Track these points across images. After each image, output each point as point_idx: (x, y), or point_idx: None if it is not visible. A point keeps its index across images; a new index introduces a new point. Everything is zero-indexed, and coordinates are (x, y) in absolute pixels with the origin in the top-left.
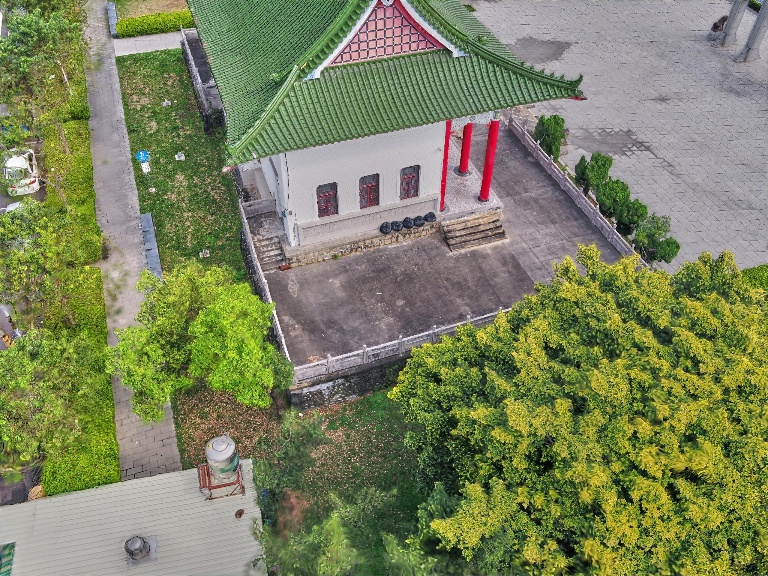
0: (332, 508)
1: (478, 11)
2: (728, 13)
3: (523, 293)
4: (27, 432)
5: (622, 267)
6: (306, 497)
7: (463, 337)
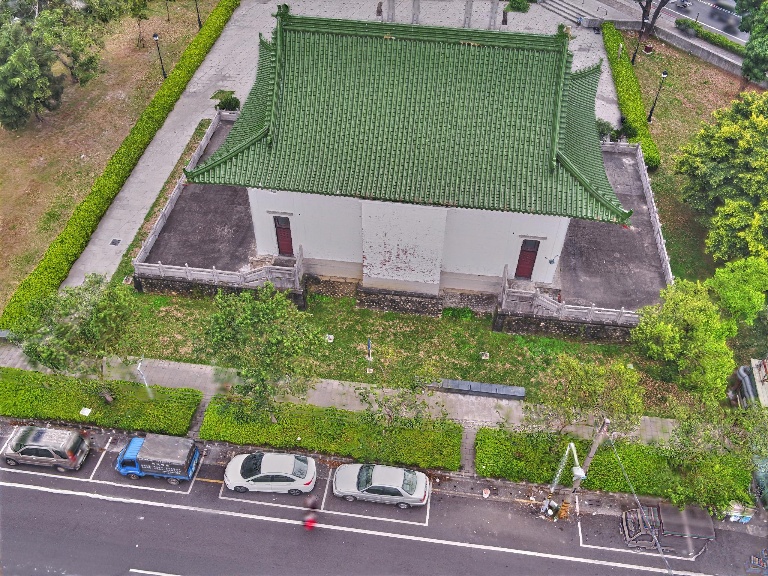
0: (753, 354)
1: (236, 91)
2: (352, 1)
3: (628, 201)
4: (767, 442)
5: (764, 122)
6: (743, 364)
7: (764, 203)
